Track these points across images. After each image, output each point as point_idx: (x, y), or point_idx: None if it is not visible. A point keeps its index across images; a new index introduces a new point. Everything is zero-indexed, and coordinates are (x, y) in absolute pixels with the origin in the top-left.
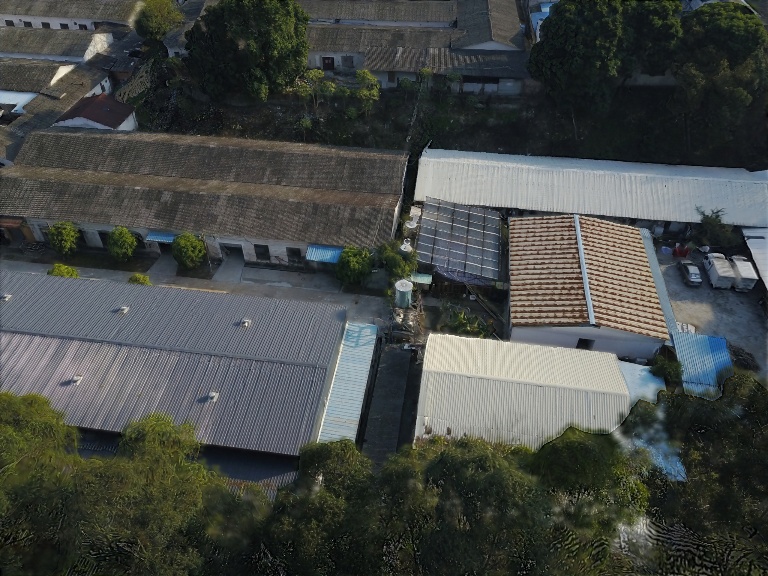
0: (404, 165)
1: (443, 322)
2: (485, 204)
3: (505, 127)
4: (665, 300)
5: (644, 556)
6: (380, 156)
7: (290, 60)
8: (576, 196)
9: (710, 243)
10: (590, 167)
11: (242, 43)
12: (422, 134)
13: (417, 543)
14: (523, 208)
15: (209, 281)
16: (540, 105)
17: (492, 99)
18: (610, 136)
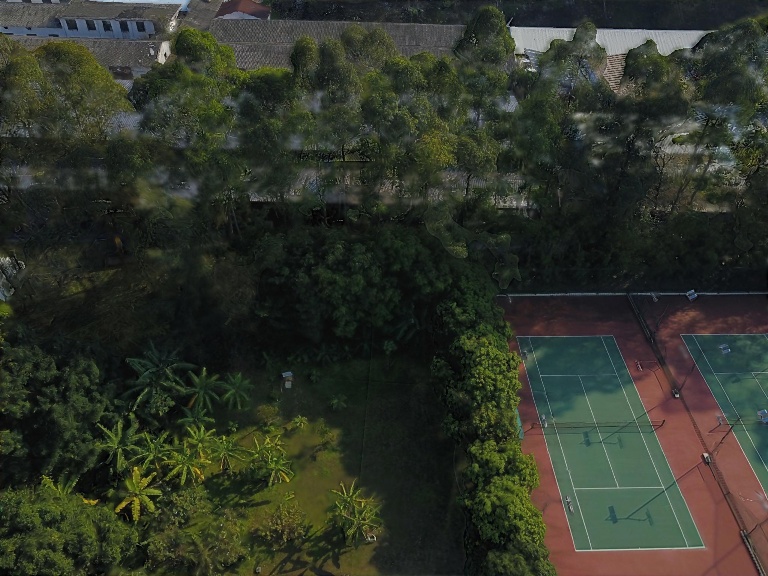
0: None
1: None
2: None
3: (556, 12)
4: None
5: None
6: None
7: None
8: (622, 46)
9: None
10: None
11: None
12: None
13: (695, 75)
14: None
15: None
16: None
17: None
18: (629, 15)
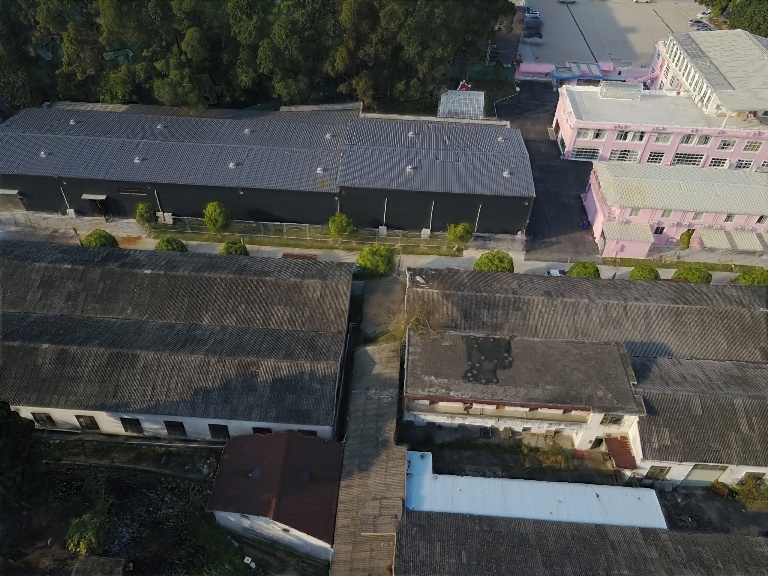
0: None
1: None
2: None
3: None
4: None
5: None
6: None
7: None
8: None
9: None
10: None
11: None
12: None
13: None
14: None
15: None
16: None
17: None
18: None
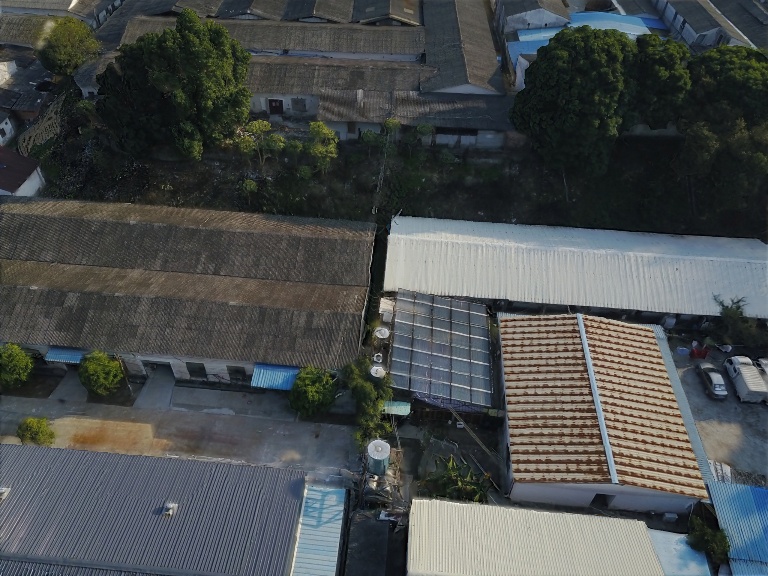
0: (371, 247)
1: (425, 462)
2: (469, 294)
3: (486, 187)
4: (693, 431)
5: None
6: (341, 234)
7: (228, 111)
8: (575, 283)
9: (732, 342)
10: (588, 243)
11: (168, 91)
12: (389, 196)
13: None
14: (514, 299)
15: (129, 409)
16: (525, 160)
17: (470, 153)
18: (606, 198)
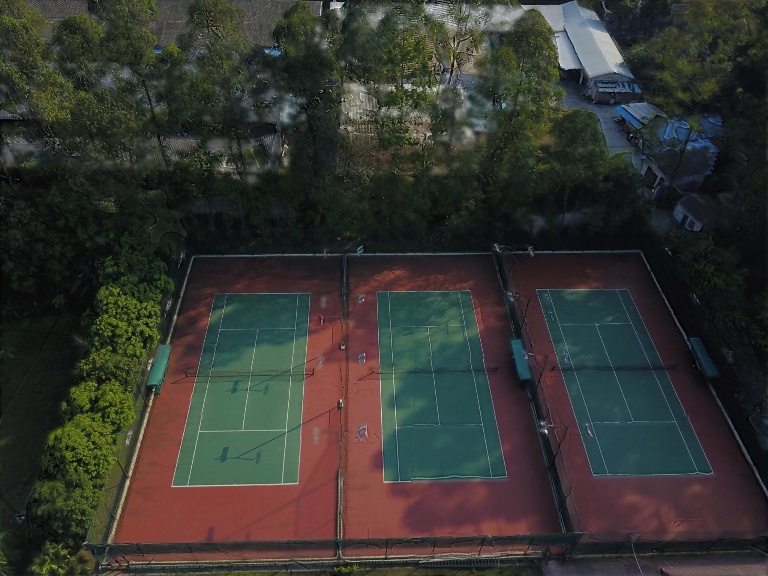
0: (320, 4)
1: None
2: None
3: None
4: None
5: (429, 16)
6: None
7: None
8: None
9: None
10: None
11: None
12: None
13: None
14: None
15: None
16: None
17: None
18: None
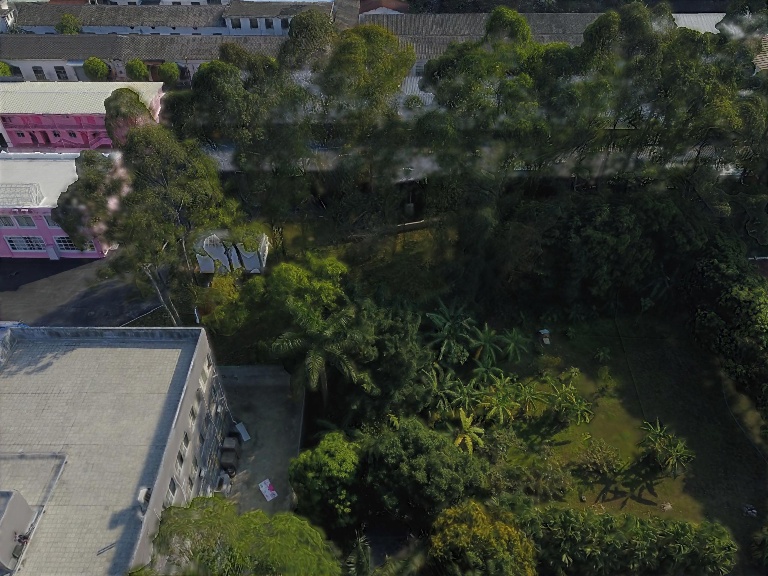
0: None
1: None
2: None
3: None
4: None
5: None
6: None
7: None
8: None
9: None
10: None
11: None
12: None
13: None
14: None
15: None
16: None
17: None
18: None
